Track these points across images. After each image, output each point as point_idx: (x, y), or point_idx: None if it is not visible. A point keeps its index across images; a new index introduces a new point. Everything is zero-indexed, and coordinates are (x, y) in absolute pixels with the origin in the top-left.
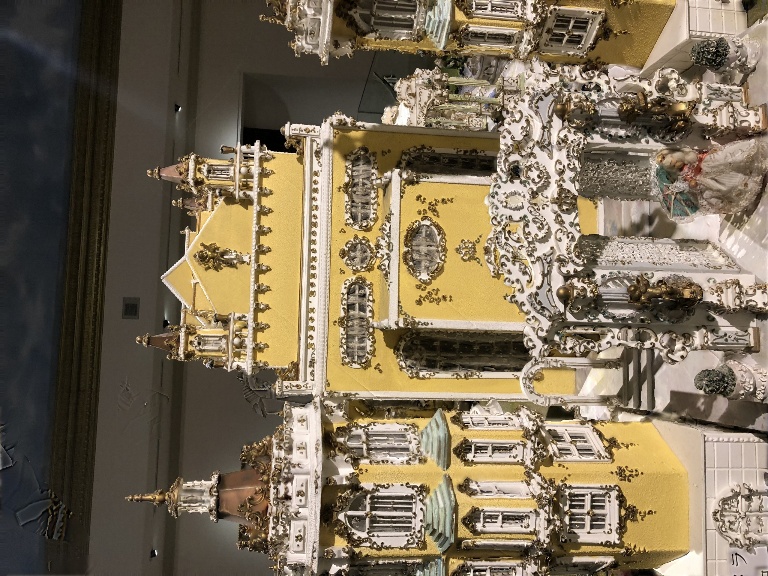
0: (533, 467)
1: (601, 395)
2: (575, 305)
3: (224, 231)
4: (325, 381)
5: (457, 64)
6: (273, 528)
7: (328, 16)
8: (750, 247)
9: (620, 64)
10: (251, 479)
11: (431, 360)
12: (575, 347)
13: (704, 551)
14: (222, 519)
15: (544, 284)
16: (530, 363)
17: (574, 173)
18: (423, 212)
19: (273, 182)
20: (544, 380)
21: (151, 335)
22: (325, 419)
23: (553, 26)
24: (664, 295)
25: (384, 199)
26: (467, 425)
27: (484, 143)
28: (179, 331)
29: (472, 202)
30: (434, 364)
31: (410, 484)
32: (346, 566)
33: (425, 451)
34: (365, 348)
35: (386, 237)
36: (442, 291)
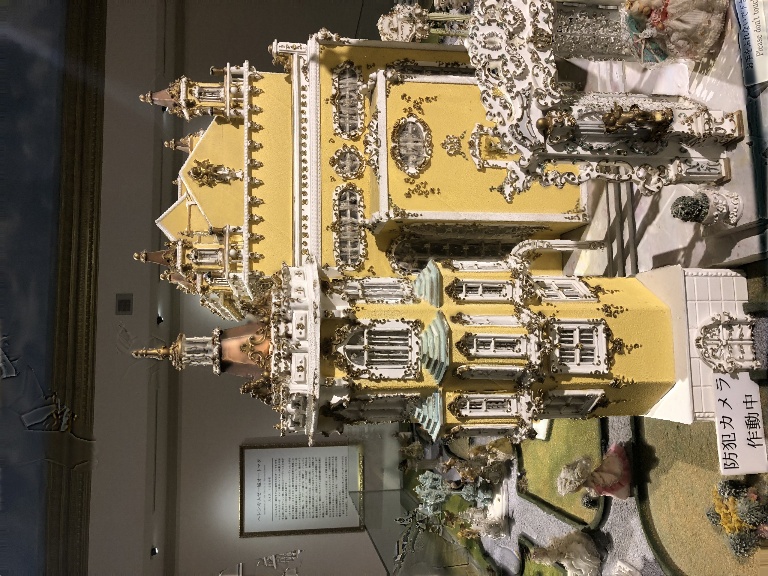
0: (522, 303)
1: None
2: (554, 135)
3: (217, 149)
4: None
5: (437, 25)
6: (275, 365)
7: None
8: (717, 87)
9: None
10: (252, 330)
11: (422, 261)
12: (556, 179)
13: (689, 377)
14: (225, 372)
15: (524, 117)
16: (517, 245)
17: (547, 14)
18: (408, 110)
19: (263, 101)
20: None
21: None
22: (321, 273)
23: None
24: (637, 117)
25: (371, 107)
26: (458, 268)
27: (465, 56)
28: (176, 245)
29: (455, 100)
30: None
31: (405, 320)
32: (347, 396)
33: (418, 295)
34: (358, 252)
35: (374, 134)
36: (430, 184)
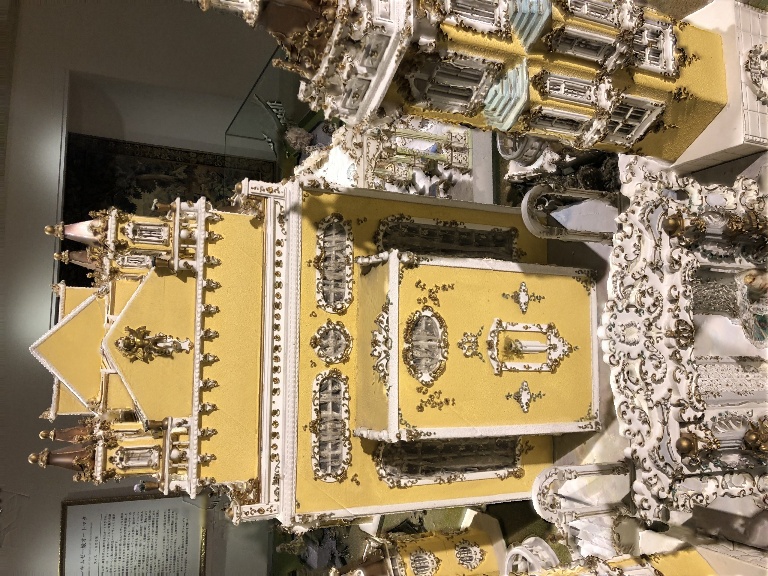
0: None
1: (608, 504)
2: (695, 458)
3: (155, 310)
4: (294, 502)
5: None
6: None
7: (386, 80)
8: None
9: (656, 156)
10: None
11: (413, 465)
12: (685, 502)
13: None
14: None
15: (664, 434)
16: (544, 476)
17: (689, 301)
18: (424, 301)
19: (221, 249)
20: (525, 476)
21: (50, 450)
22: None
23: (611, 113)
24: None
25: (365, 278)
26: None
27: (463, 214)
28: (94, 445)
29: (473, 289)
30: (416, 469)
31: None
32: None
33: None
34: (340, 456)
35: (384, 331)
36: (444, 393)
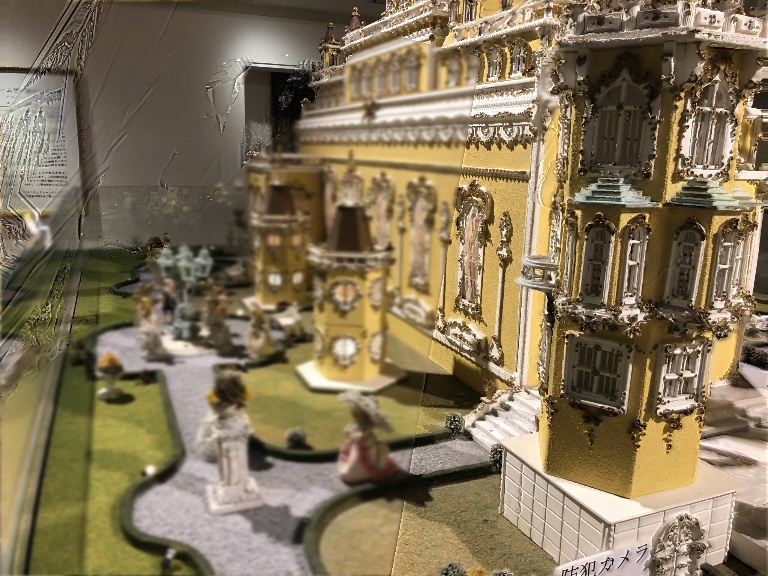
0: None
1: None
2: None
3: None
4: None
5: None
6: None
7: None
8: None
9: None
10: None
11: None
12: None
13: None
14: None
15: None
16: None
17: None
18: None
19: None
20: None
21: None
22: None
23: None
24: None
25: None
26: None
27: None
28: None
29: None
30: None
31: None
32: None
33: None
34: None
35: None
36: None
